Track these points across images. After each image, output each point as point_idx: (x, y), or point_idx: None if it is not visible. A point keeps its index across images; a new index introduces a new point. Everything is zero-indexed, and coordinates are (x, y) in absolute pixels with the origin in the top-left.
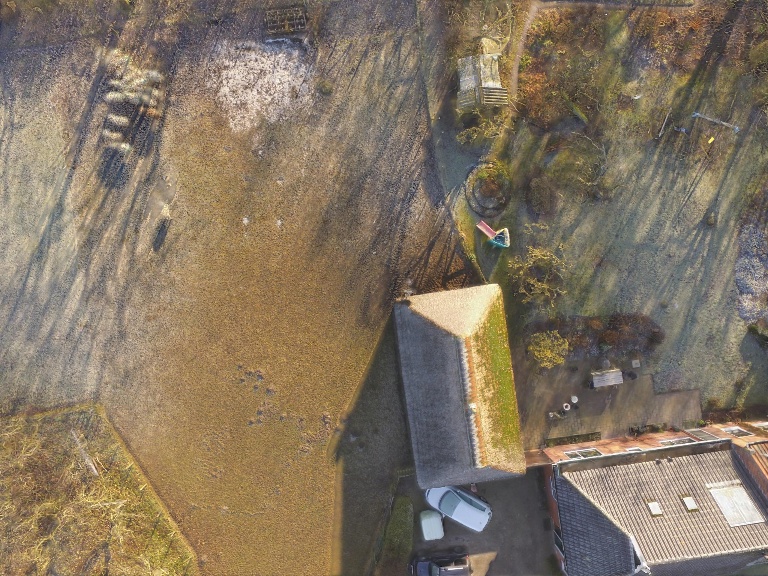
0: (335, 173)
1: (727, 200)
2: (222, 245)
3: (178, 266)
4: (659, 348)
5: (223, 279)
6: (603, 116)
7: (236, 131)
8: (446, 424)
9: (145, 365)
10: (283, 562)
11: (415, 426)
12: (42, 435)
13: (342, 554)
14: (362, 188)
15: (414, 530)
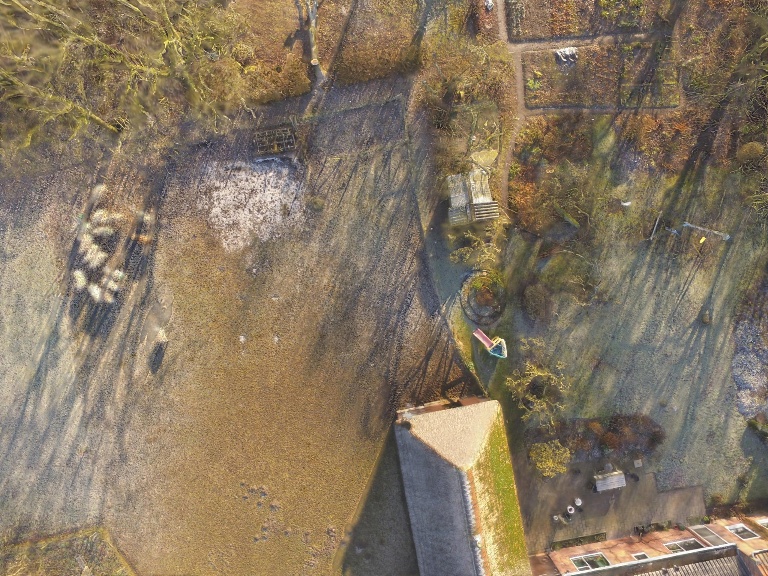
0: (330, 288)
1: (721, 297)
2: (220, 364)
3: (176, 387)
4: (660, 447)
5: (222, 398)
6: None
7: (229, 251)
8: (451, 551)
9: (147, 487)
10: None
11: (420, 547)
12: (46, 563)
13: None
14: (357, 301)
15: None
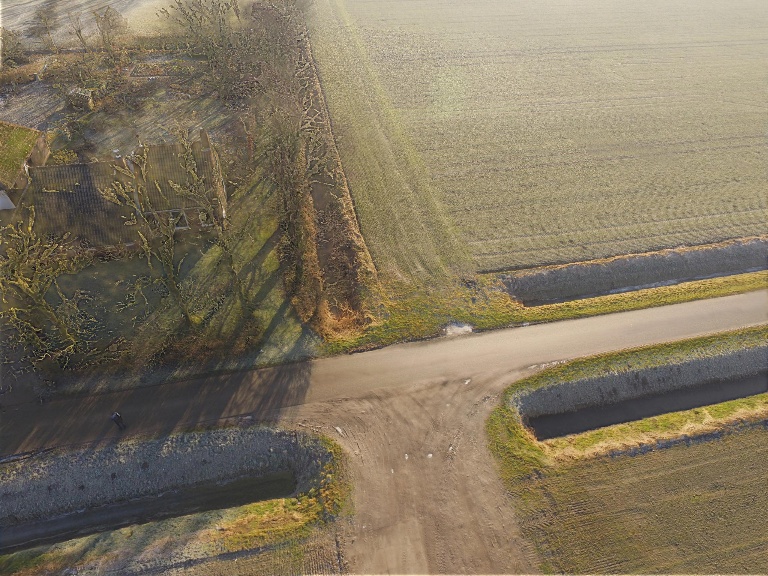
0: None
1: None
2: None
3: None
4: None
5: None
6: (144, 109)
7: None
8: None
9: None
10: None
11: None
12: None
13: None
14: None
15: None
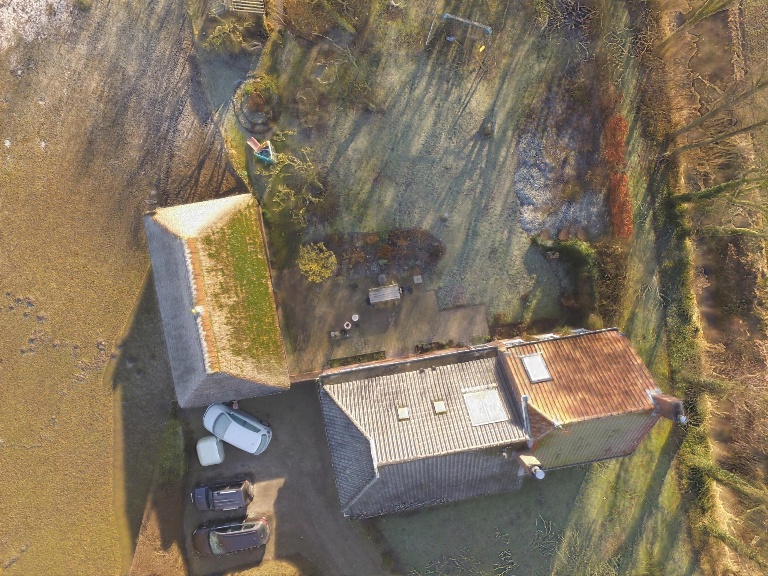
0: (99, 92)
1: (504, 110)
2: None
3: None
4: (441, 263)
5: None
6: (372, 27)
7: None
8: (185, 333)
9: None
10: (63, 496)
11: (169, 342)
12: None
13: (124, 486)
14: (127, 107)
15: (197, 458)
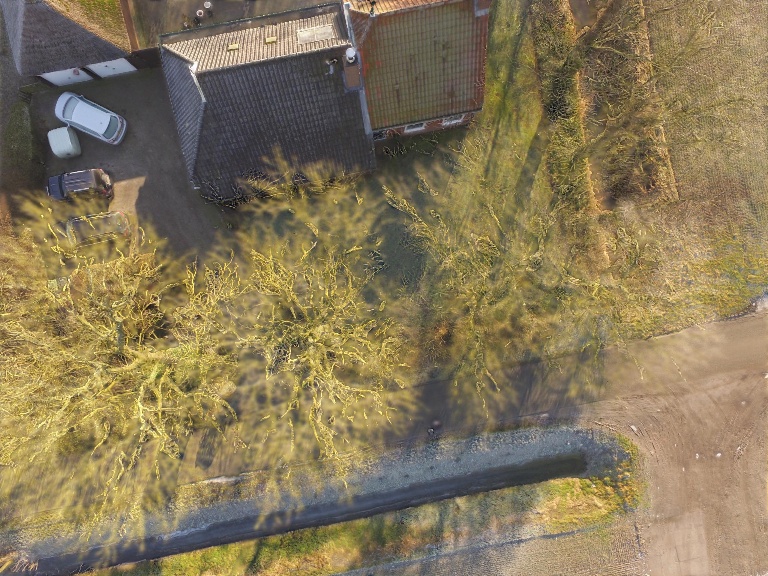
0: None
1: None
2: None
3: None
4: None
5: None
6: None
7: None
8: None
9: None
10: None
11: (2, 3)
12: None
13: None
14: None
15: (55, 157)
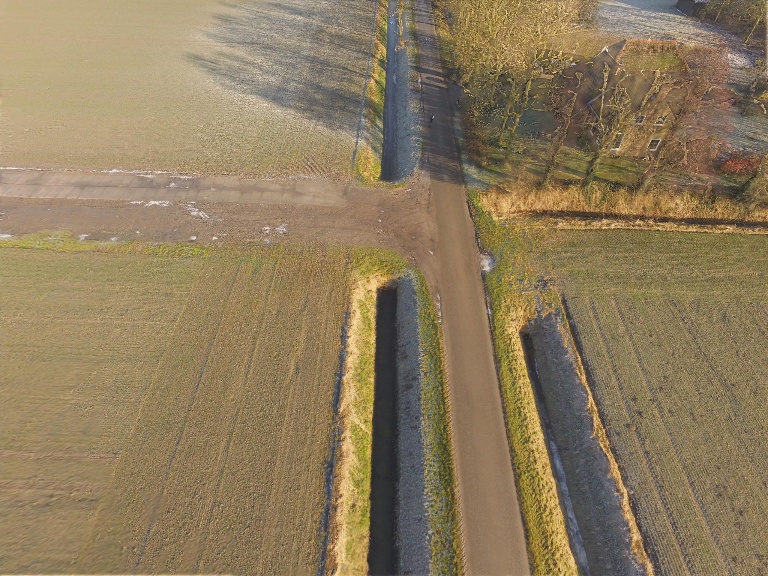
0: None
1: None
2: None
3: None
4: None
5: None
6: None
7: None
8: None
9: None
10: None
11: None
12: None
13: None
14: None
15: None
